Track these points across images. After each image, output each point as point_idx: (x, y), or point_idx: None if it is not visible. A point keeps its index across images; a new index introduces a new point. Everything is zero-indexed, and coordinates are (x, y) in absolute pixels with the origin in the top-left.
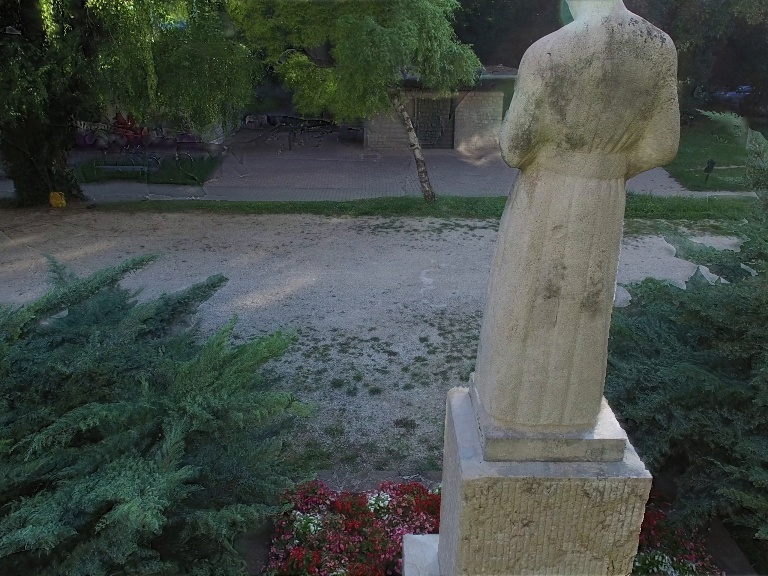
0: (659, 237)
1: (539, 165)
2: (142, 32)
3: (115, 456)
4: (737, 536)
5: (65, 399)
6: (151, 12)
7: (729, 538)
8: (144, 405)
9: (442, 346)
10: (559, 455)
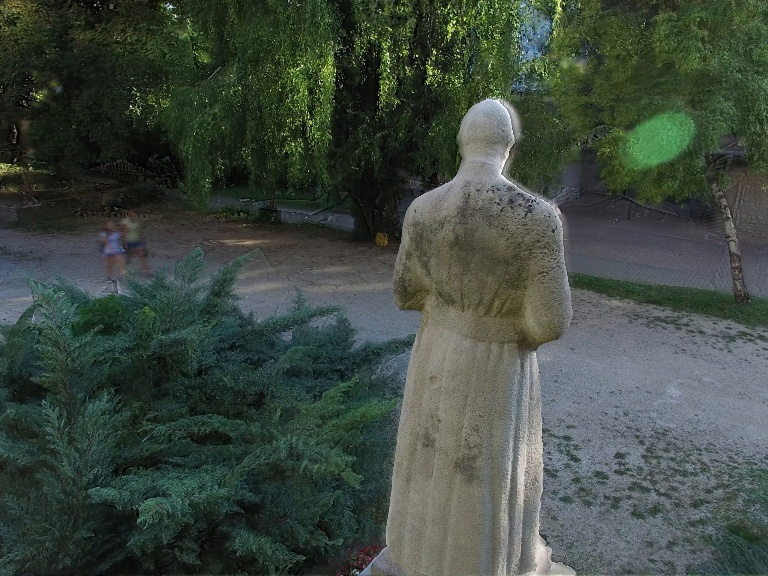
0: None
1: (427, 312)
2: (460, 107)
3: (218, 461)
4: None
5: (218, 405)
6: (481, 88)
7: None
8: (253, 429)
9: (636, 469)
10: None
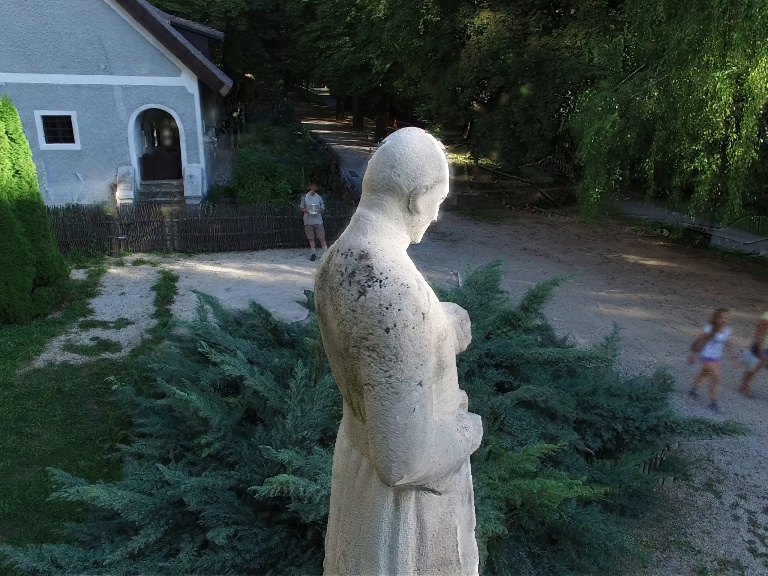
0: None
1: None
2: None
3: None
4: None
5: None
6: None
7: None
8: None
9: None
10: None
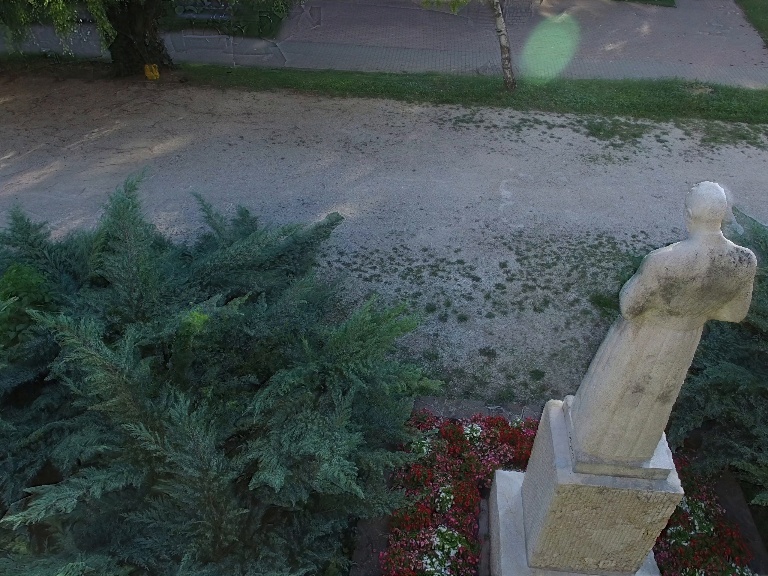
0: (736, 148)
1: (645, 317)
2: None
3: (298, 407)
4: (741, 482)
5: (253, 356)
6: None
7: (735, 481)
8: (314, 370)
9: (519, 273)
10: (624, 473)
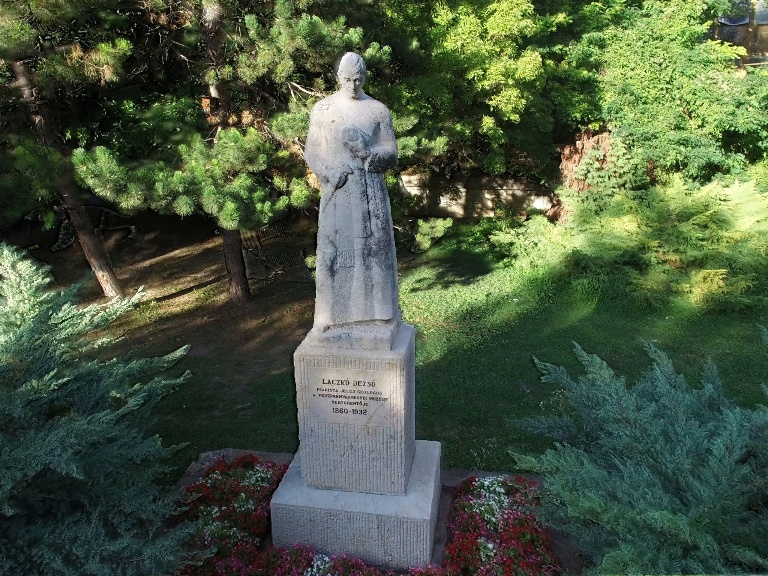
0: None
1: None
2: None
3: None
4: None
5: None
6: None
7: None
8: None
9: None
10: None
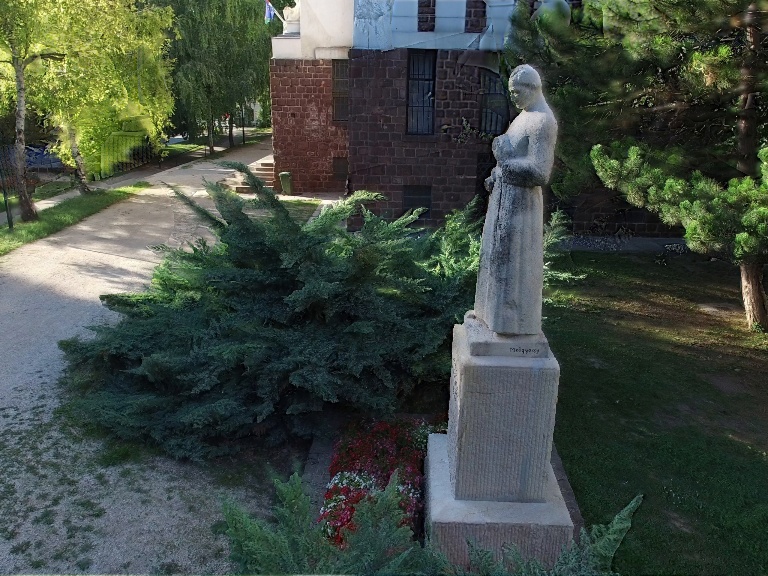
0: None
1: None
2: None
3: None
4: None
5: None
6: None
7: None
8: None
9: (4, 524)
10: None
